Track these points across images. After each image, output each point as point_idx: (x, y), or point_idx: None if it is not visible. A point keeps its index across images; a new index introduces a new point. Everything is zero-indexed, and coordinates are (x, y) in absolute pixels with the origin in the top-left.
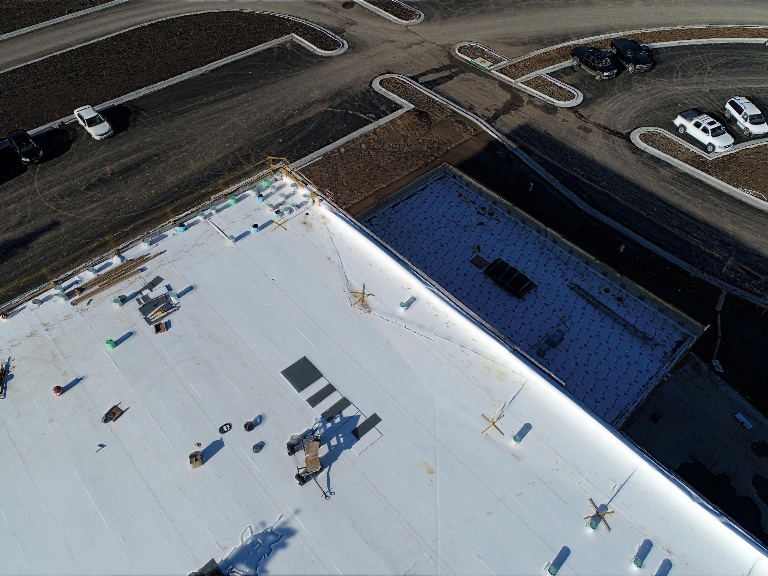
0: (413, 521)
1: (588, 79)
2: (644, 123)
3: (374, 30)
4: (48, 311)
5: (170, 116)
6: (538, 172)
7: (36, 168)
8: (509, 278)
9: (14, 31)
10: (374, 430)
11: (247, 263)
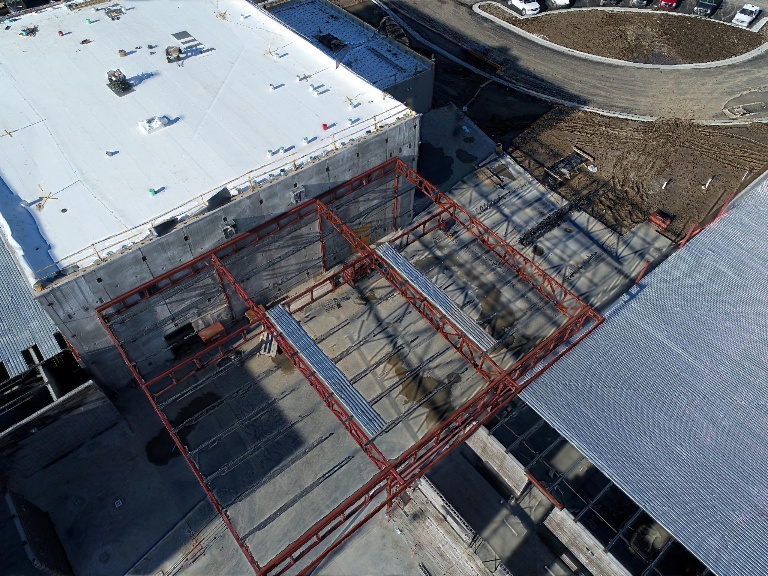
0: None
1: None
2: None
3: None
4: (58, 12)
5: None
6: (397, 21)
7: None
8: (330, 40)
9: None
10: (211, 52)
11: (166, 1)
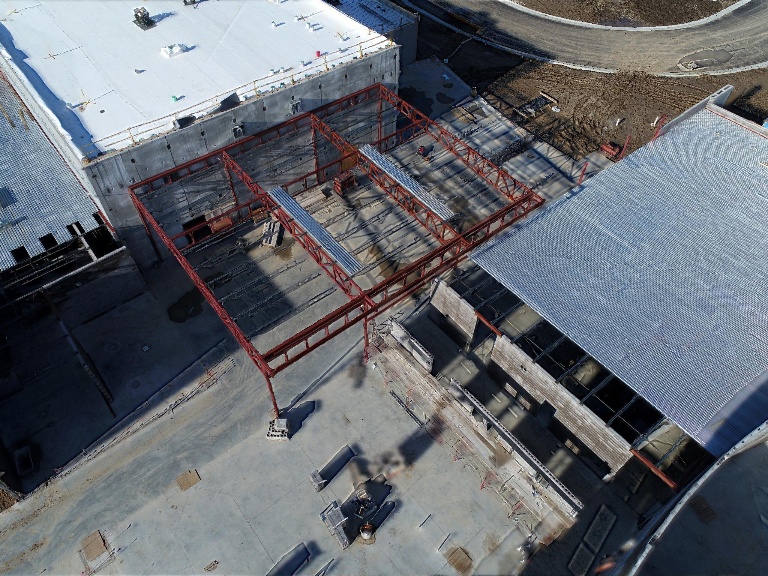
0: None
1: None
2: None
3: None
4: None
5: None
6: None
7: None
8: None
9: None
10: None
11: None
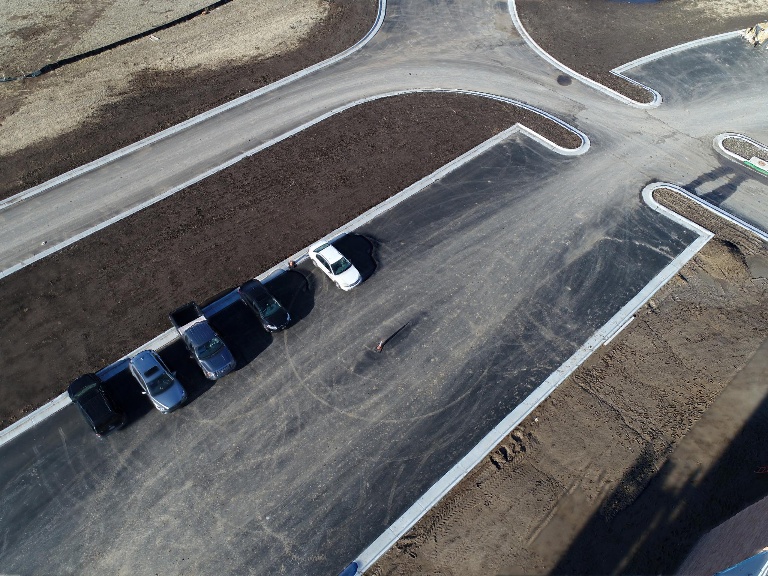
0: None
1: None
2: None
3: (610, 117)
4: None
5: (418, 250)
6: None
7: (283, 336)
8: None
9: (186, 120)
10: None
11: None
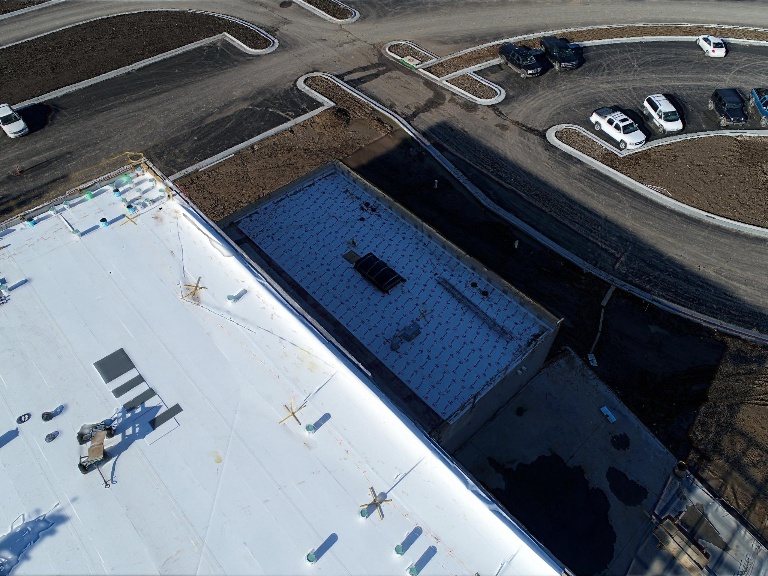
0: (188, 509)
1: (514, 77)
2: (562, 120)
3: (307, 29)
4: None
5: (89, 114)
6: (447, 169)
7: None
8: (375, 273)
9: None
10: (172, 420)
11: (88, 257)
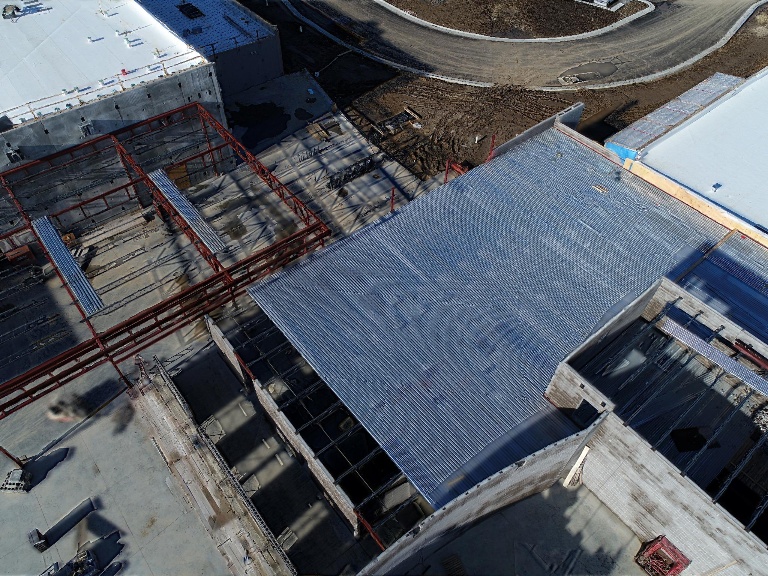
0: (45, 29)
1: None
2: None
3: None
4: None
5: None
6: None
7: None
8: (188, 9)
9: None
10: (47, 11)
11: None
